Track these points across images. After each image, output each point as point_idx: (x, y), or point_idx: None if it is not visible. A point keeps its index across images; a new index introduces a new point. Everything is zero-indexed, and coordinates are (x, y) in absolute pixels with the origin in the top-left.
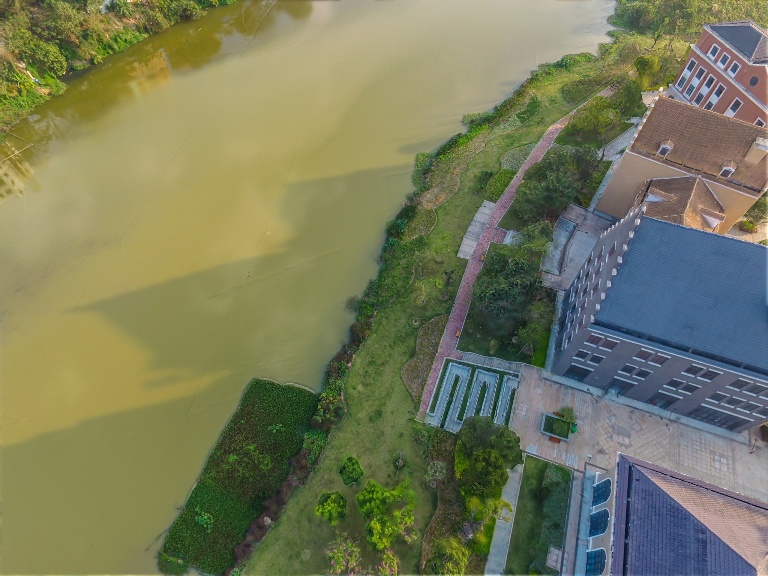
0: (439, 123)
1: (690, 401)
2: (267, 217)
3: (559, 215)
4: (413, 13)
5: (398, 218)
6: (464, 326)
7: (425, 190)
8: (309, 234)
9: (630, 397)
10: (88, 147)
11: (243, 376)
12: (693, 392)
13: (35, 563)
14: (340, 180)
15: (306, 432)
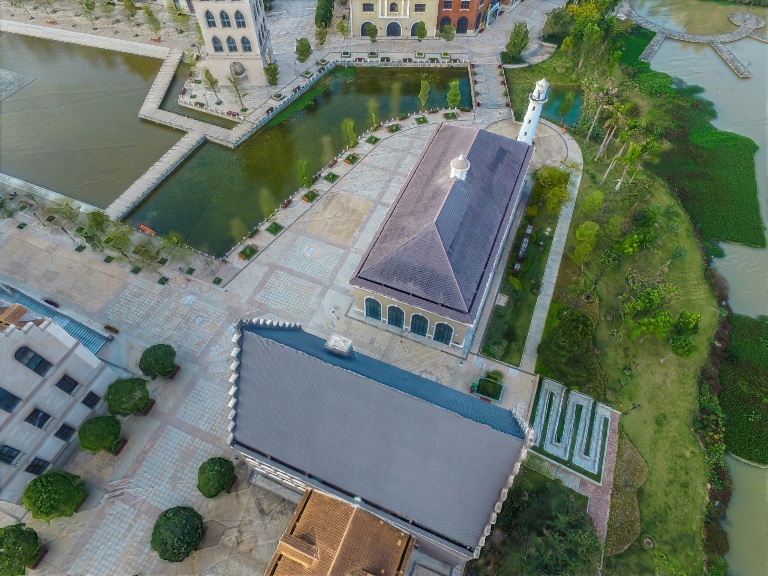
0: None
1: None
2: None
3: None
4: None
5: None
6: None
7: None
8: None
9: None
10: None
11: None
12: None
13: None
14: None
15: None
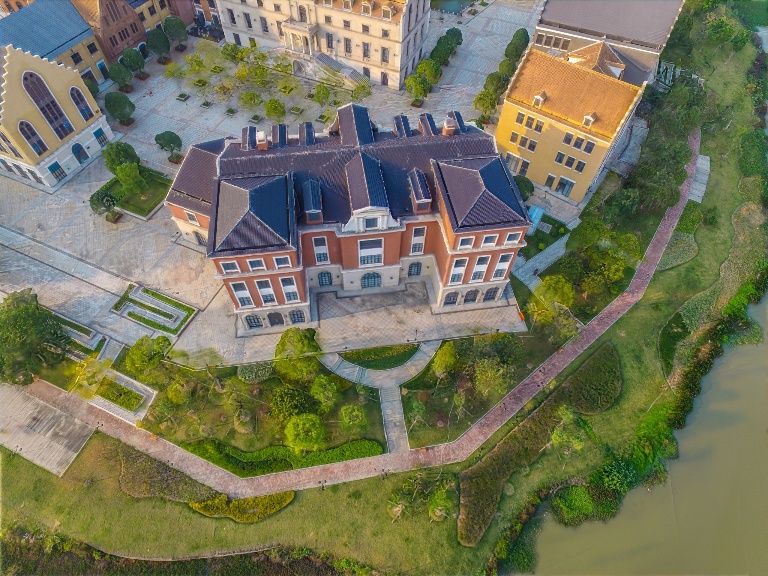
0: None
1: None
2: None
3: None
4: None
5: None
6: None
7: (764, 225)
8: None
9: None
10: None
11: None
12: None
13: None
14: None
15: None
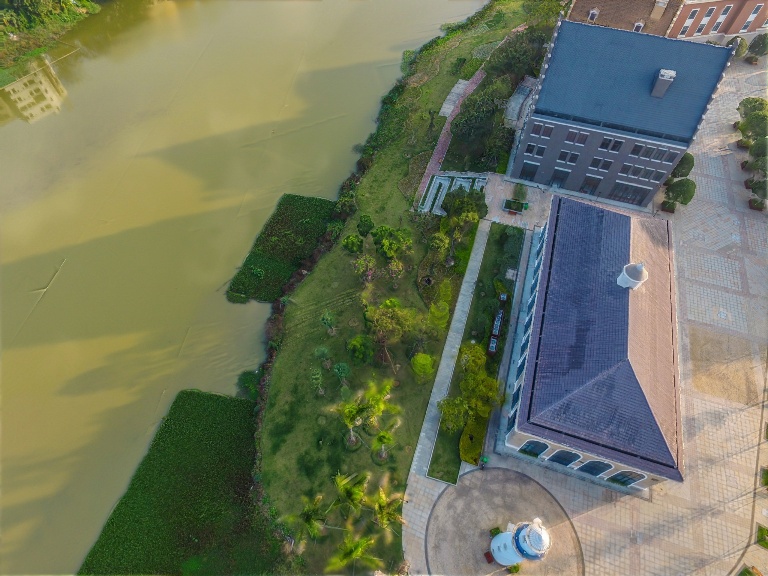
0: (421, 30)
1: (608, 180)
2: (283, 96)
3: (518, 83)
4: None
5: (390, 93)
6: (445, 157)
7: (411, 75)
8: (319, 105)
9: (568, 189)
10: (127, 49)
11: (276, 193)
12: (609, 169)
13: (136, 299)
14: (341, 70)
15: (328, 223)
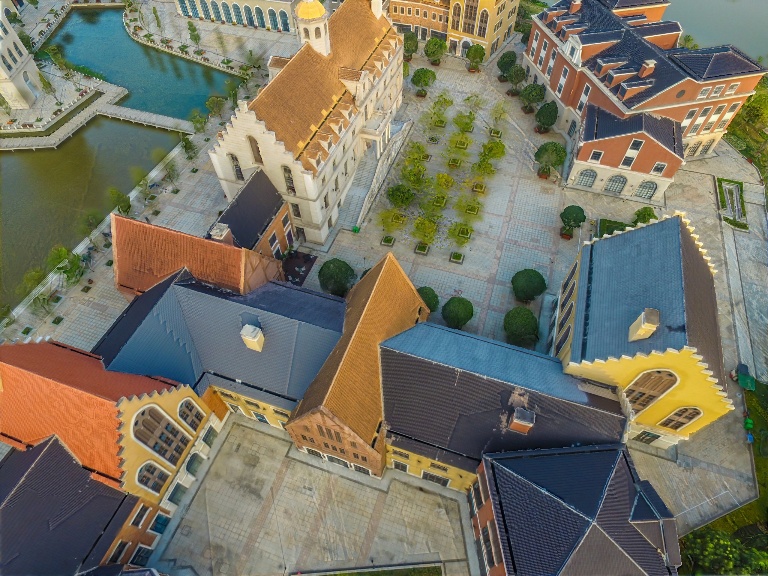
0: None
1: None
2: None
3: None
4: None
5: None
6: None
7: None
8: None
9: None
10: None
11: None
12: None
13: None
14: None
15: None
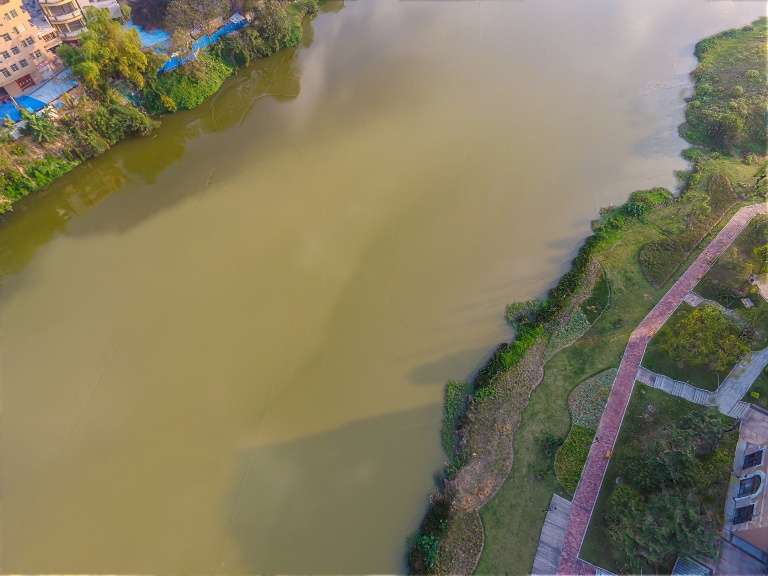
0: (474, 321)
1: None
2: (223, 522)
3: None
4: (428, 122)
5: (424, 532)
6: None
7: (461, 464)
8: (286, 569)
9: None
10: None
11: None
12: None
13: None
14: (334, 441)
15: None
